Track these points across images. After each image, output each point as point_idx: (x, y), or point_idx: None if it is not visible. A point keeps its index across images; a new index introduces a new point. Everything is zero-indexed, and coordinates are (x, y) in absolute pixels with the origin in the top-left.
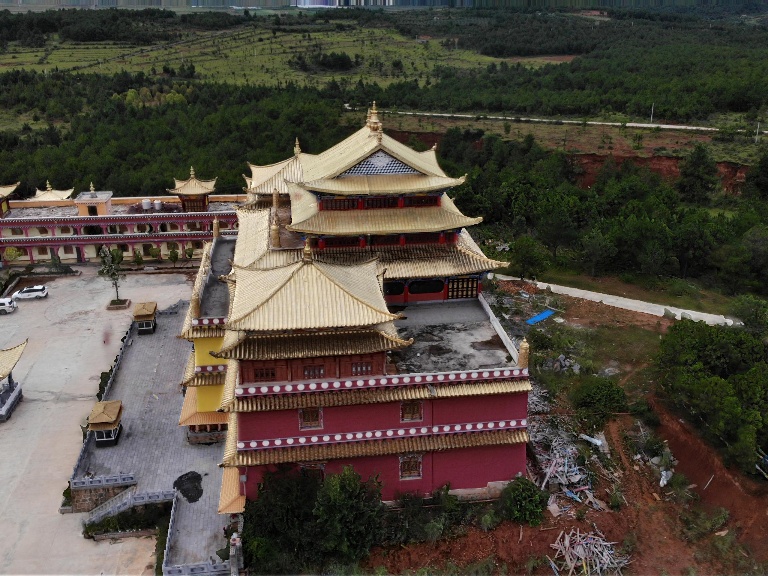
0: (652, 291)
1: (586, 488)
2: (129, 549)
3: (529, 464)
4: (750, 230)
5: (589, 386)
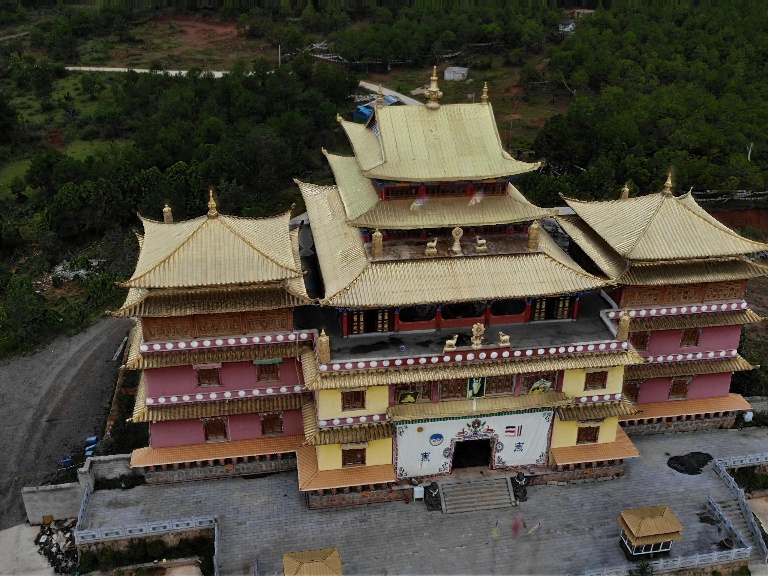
0: (279, 209)
1: None
2: (762, 520)
3: None
4: (256, 132)
5: None
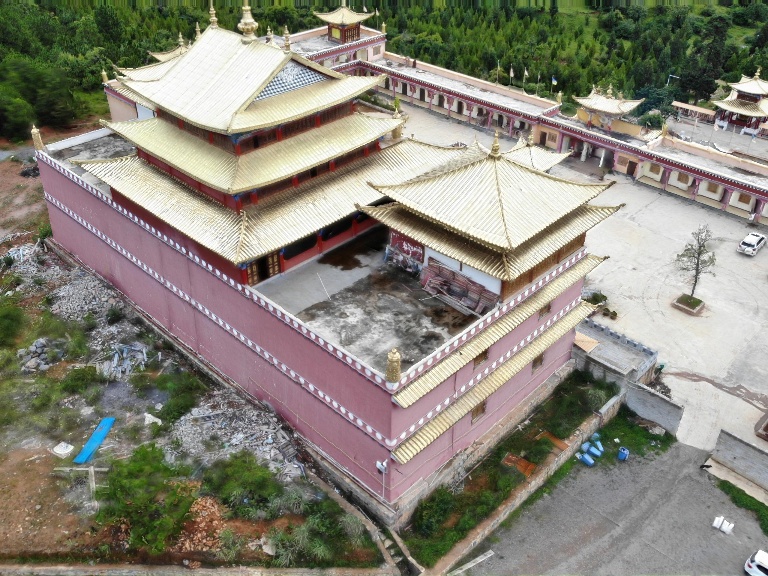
0: None
1: (4, 254)
2: None
3: (57, 260)
4: None
5: (2, 317)
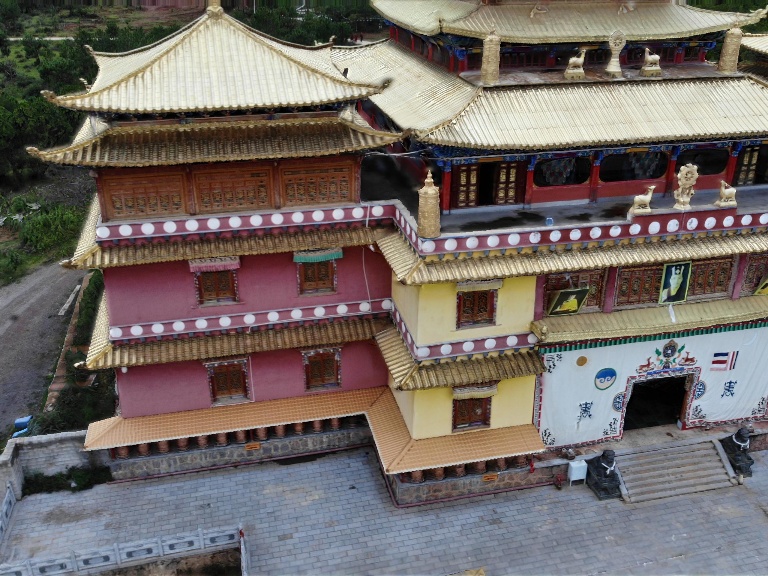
0: None
1: None
2: None
3: None
4: None
5: None
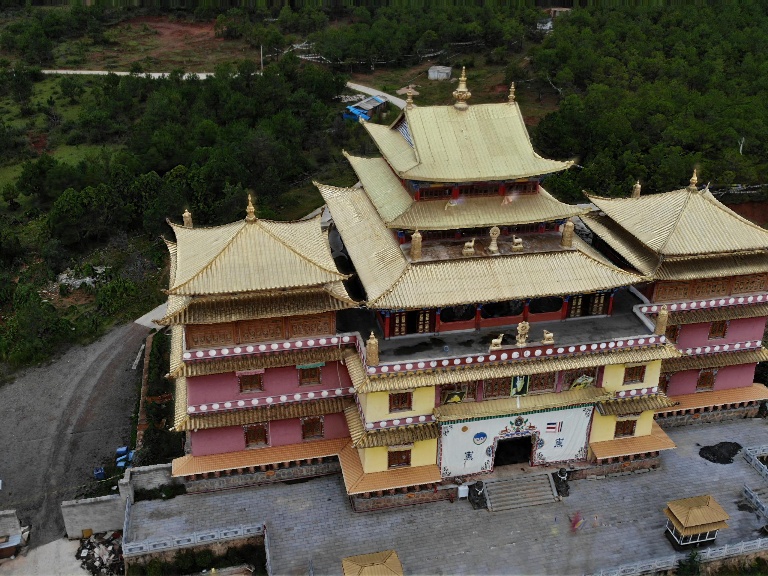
0: (282, 211)
1: None
2: None
3: None
4: (254, 135)
5: None
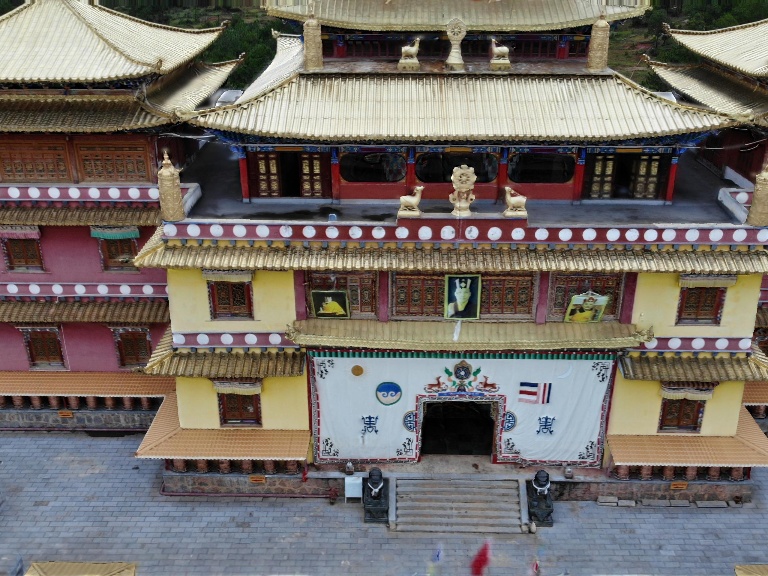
0: None
1: None
2: None
3: None
4: None
5: None
